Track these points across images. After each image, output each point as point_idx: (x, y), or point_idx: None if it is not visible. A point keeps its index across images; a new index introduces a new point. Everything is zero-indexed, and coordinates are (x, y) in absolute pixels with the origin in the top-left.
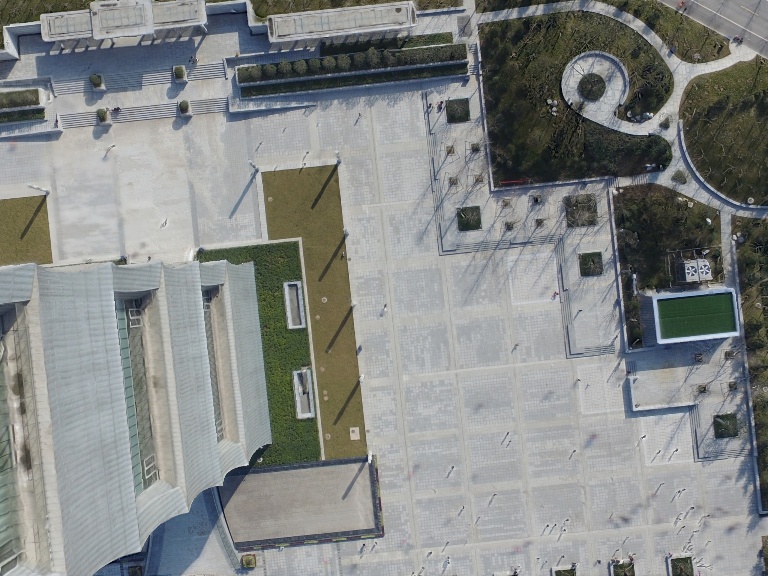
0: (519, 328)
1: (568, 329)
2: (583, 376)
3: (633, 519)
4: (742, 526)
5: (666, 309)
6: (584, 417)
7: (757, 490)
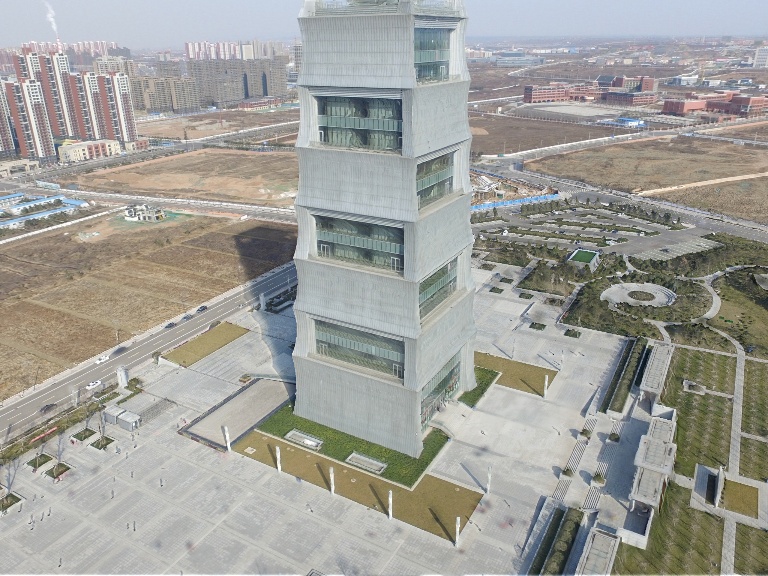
0: None
1: None
2: None
3: None
4: None
5: None
6: None
7: None
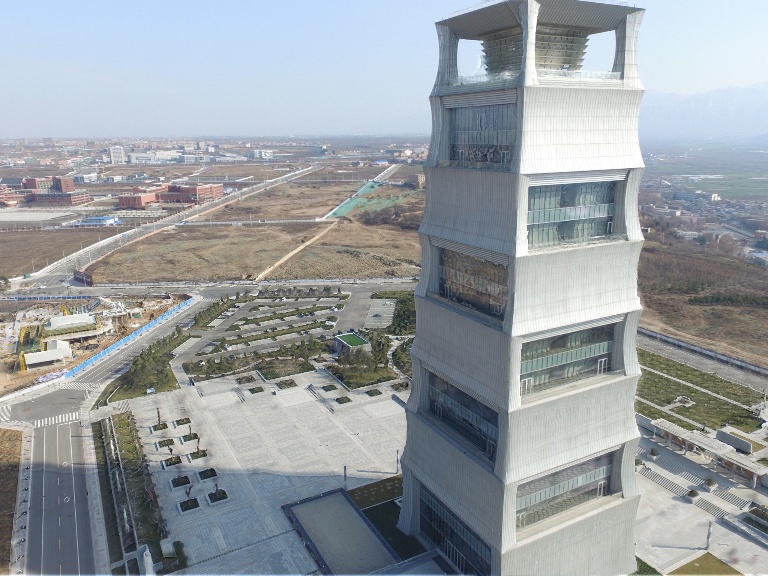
0: None
1: None
2: None
3: None
4: None
5: None
6: None
7: None
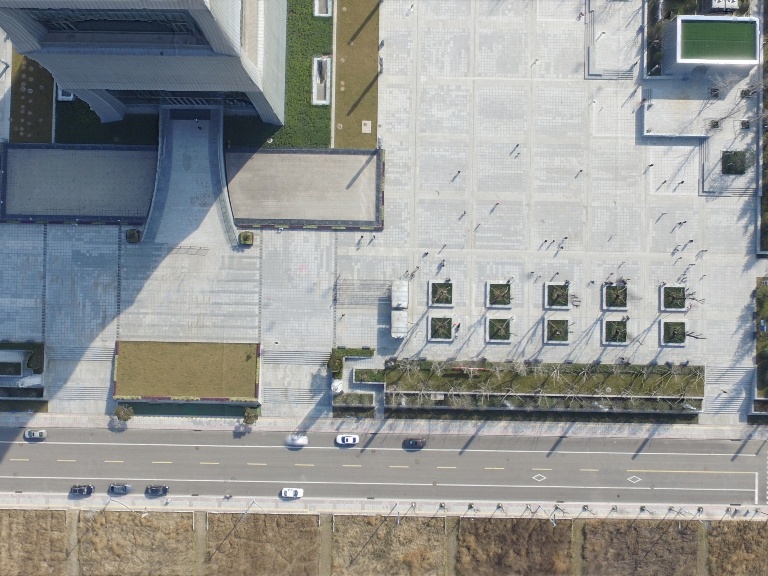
0: (541, 44)
1: (589, 49)
2: (598, 98)
3: (631, 245)
4: (738, 265)
5: (689, 31)
6: (595, 138)
7: (757, 230)
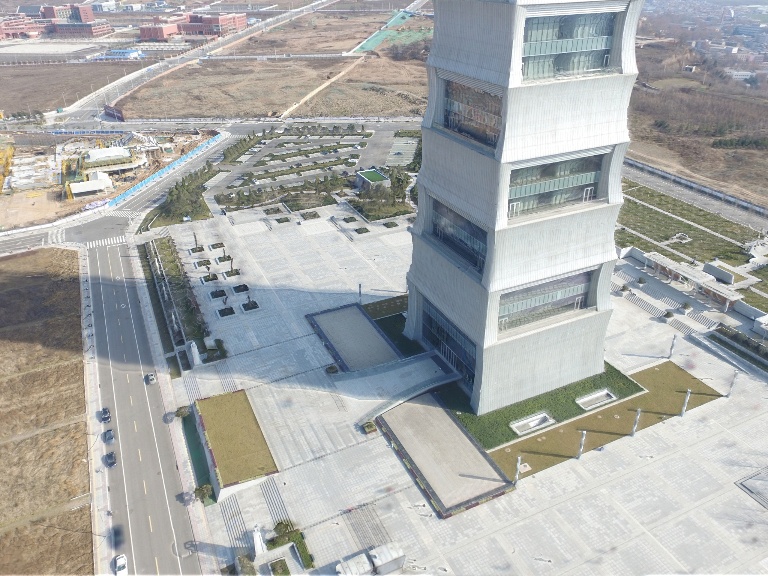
0: None
1: None
2: None
3: None
4: None
5: None
6: None
7: None
